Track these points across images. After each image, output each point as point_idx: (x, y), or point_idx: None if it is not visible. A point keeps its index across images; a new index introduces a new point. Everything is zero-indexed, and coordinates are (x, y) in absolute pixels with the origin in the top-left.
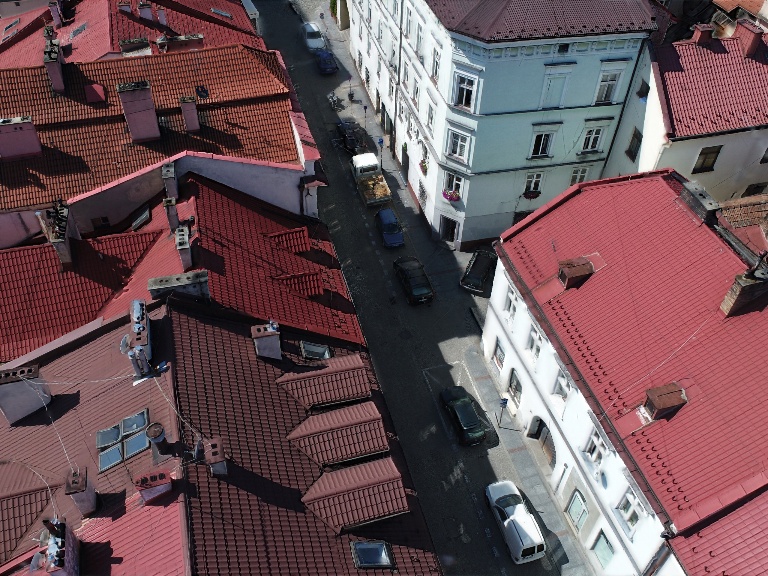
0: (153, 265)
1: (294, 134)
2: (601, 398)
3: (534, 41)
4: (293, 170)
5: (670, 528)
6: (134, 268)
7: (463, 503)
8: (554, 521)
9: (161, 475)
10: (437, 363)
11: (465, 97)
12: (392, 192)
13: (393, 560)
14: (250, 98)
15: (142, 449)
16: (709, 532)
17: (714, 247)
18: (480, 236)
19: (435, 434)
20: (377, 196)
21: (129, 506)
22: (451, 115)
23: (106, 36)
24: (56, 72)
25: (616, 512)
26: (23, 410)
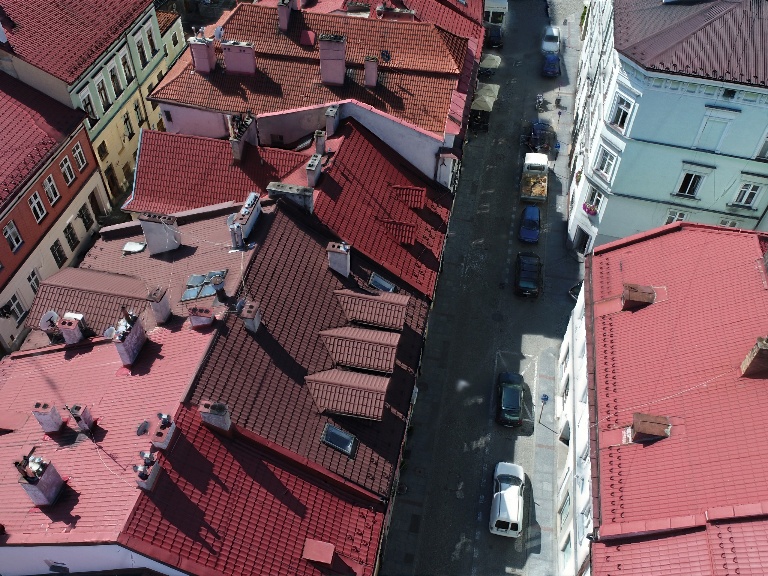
0: (294, 179)
1: None
2: (601, 409)
3: (696, 79)
4: (434, 139)
5: (597, 532)
6: (282, 179)
7: (473, 467)
8: (545, 516)
9: (207, 310)
10: (513, 350)
11: (621, 118)
12: (552, 195)
13: (355, 452)
14: (425, 71)
15: (210, 294)
16: (627, 549)
17: (767, 312)
18: None
19: (479, 405)
20: (533, 193)
21: (184, 327)
22: (605, 132)
23: None
24: (284, 14)
25: (580, 516)
26: (160, 247)
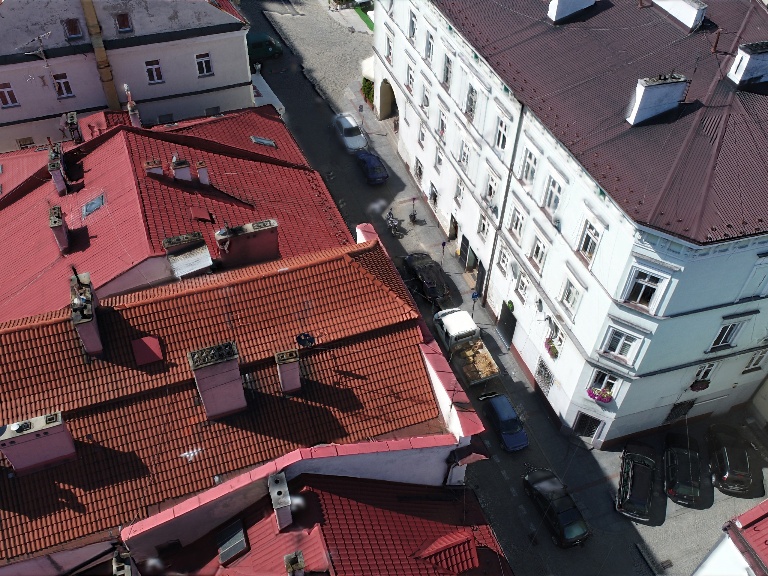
0: None
1: (430, 379)
2: None
3: None
4: (443, 446)
5: None
6: None
7: None
8: None
9: None
10: None
11: (642, 294)
12: (493, 359)
13: None
14: (365, 331)
15: None
16: None
17: None
18: (627, 432)
19: None
20: (481, 374)
21: None
22: (617, 312)
23: (138, 222)
24: (91, 332)
25: None
26: None
